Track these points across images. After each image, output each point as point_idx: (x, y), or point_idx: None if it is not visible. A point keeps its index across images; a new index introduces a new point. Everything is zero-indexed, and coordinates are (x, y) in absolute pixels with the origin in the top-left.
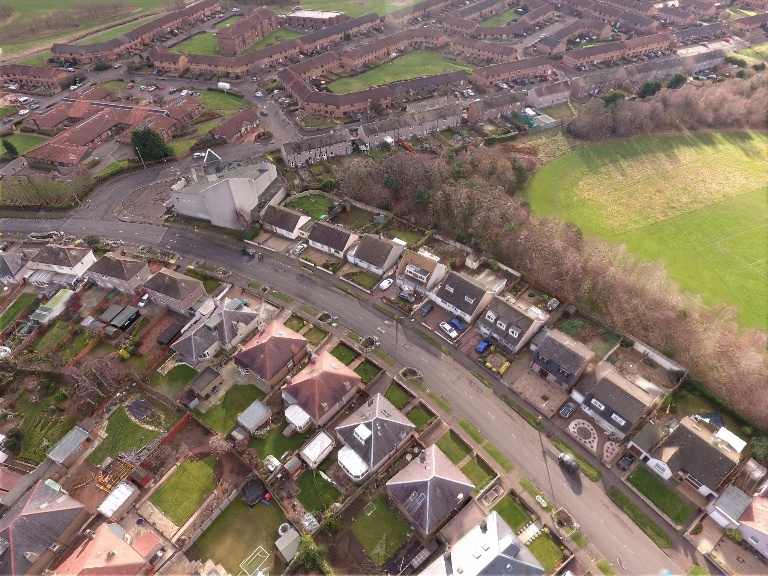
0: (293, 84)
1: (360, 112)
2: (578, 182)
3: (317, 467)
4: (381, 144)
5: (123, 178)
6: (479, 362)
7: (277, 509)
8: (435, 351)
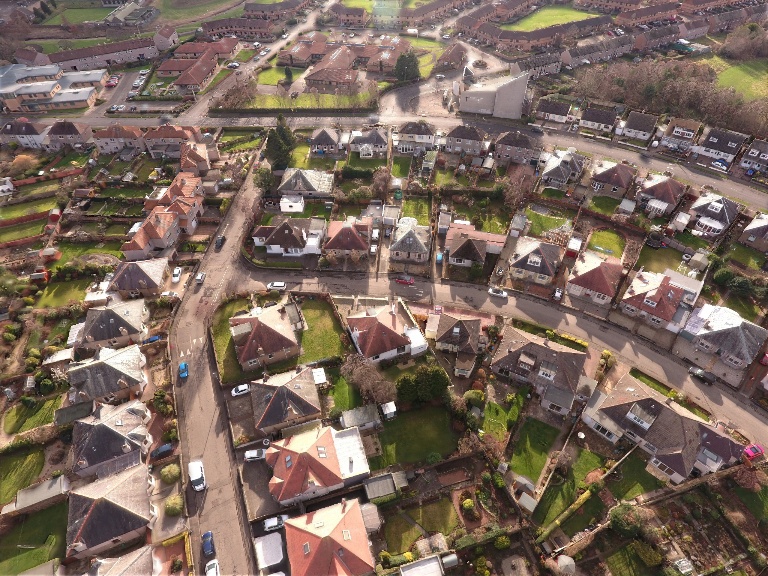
0: (480, 26)
1: (542, 46)
2: (750, 85)
3: (684, 231)
4: (580, 65)
5: (394, 92)
6: (753, 180)
7: (674, 250)
8: (717, 177)
